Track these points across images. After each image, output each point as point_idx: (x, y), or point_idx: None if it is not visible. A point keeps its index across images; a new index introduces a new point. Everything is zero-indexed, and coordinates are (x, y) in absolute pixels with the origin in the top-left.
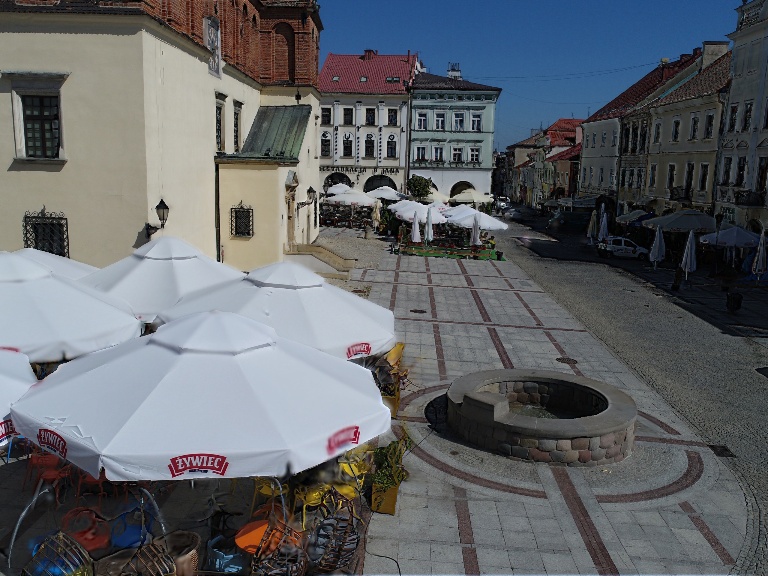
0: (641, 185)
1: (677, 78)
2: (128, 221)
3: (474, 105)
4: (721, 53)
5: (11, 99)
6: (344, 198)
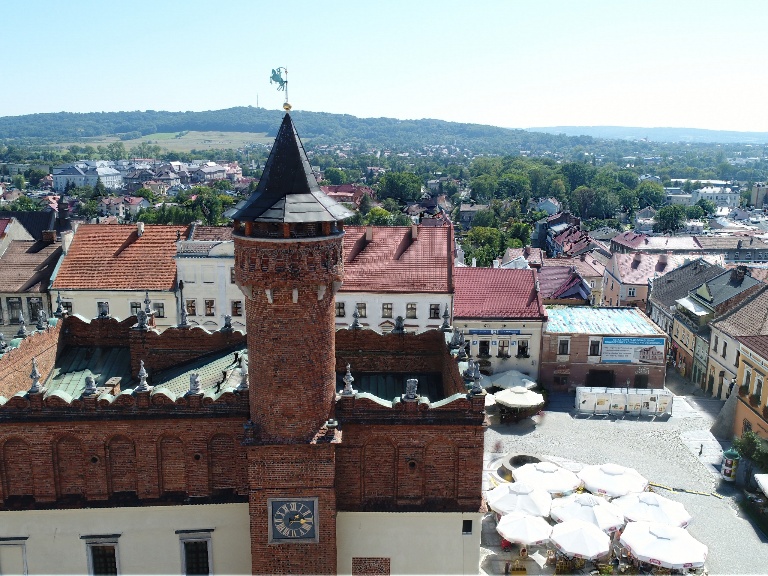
0: None
1: (1, 249)
2: None
3: None
4: (71, 239)
5: None
6: None
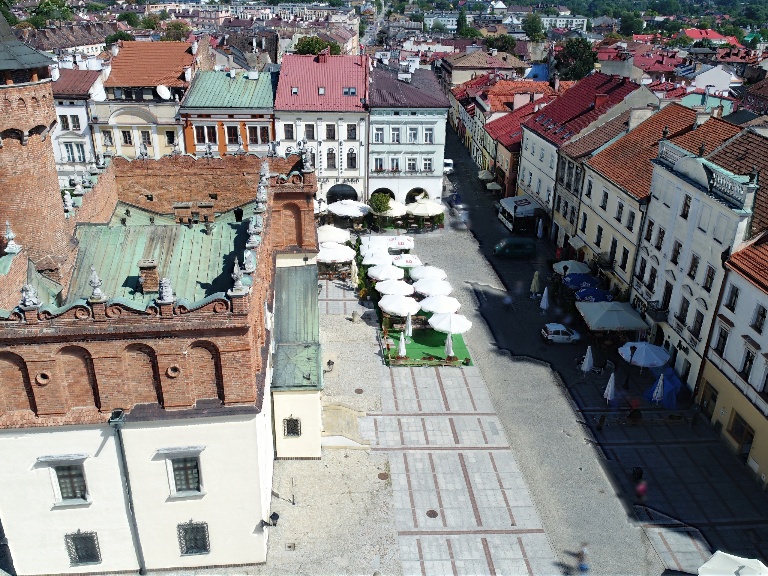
0: (574, 222)
1: (608, 114)
2: (249, 520)
3: (427, 120)
4: (646, 117)
5: (165, 463)
6: (324, 255)
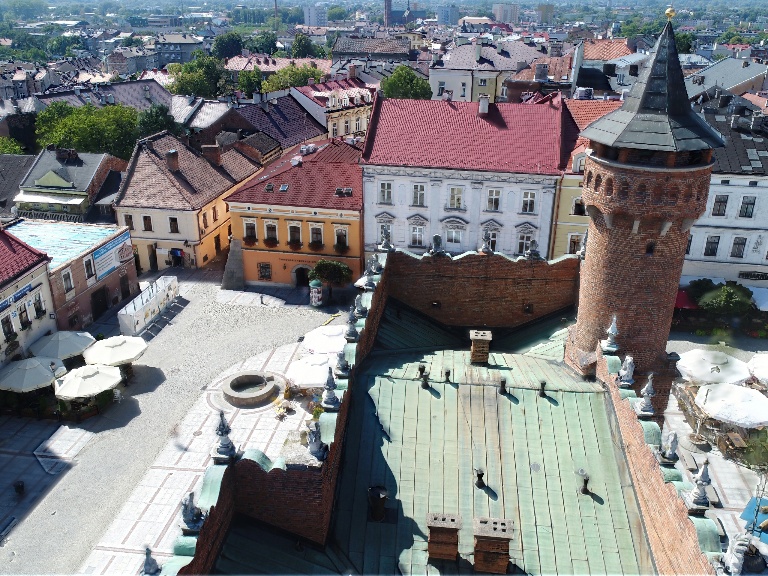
0: None
1: None
2: None
3: None
4: None
5: None
6: None
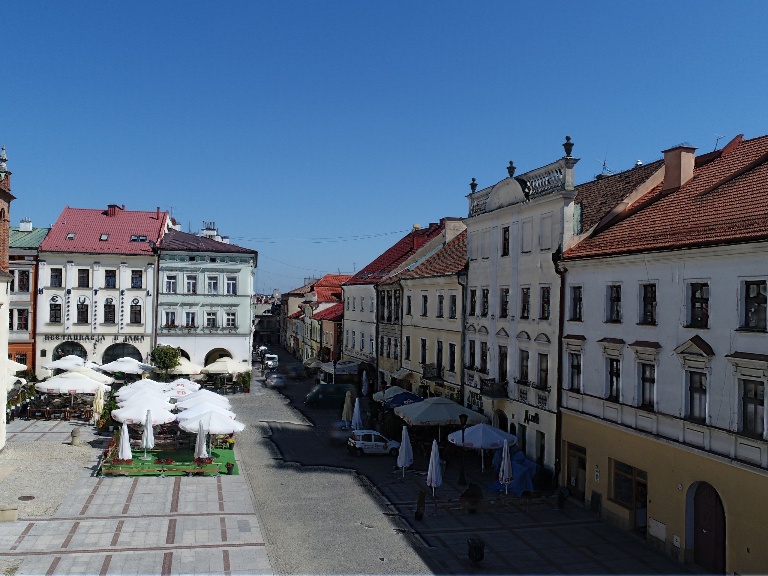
0: (398, 356)
1: (426, 247)
2: None
3: (228, 267)
4: (462, 228)
5: None
6: (59, 384)
